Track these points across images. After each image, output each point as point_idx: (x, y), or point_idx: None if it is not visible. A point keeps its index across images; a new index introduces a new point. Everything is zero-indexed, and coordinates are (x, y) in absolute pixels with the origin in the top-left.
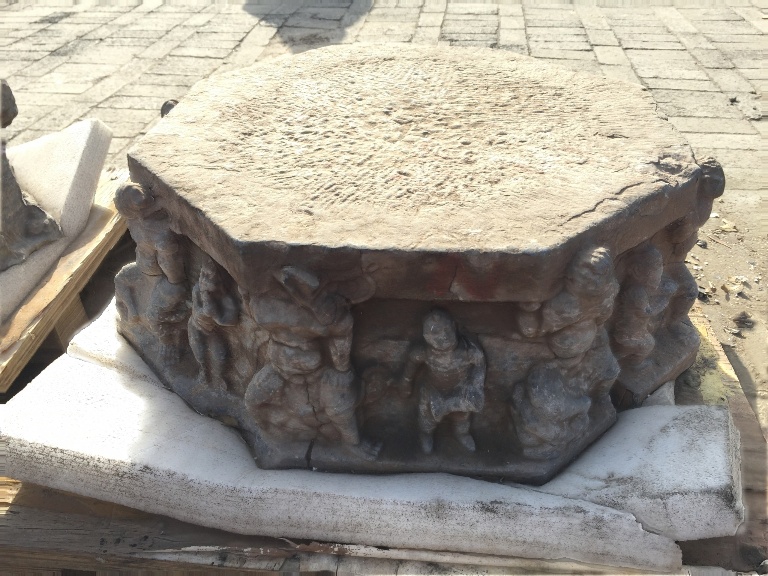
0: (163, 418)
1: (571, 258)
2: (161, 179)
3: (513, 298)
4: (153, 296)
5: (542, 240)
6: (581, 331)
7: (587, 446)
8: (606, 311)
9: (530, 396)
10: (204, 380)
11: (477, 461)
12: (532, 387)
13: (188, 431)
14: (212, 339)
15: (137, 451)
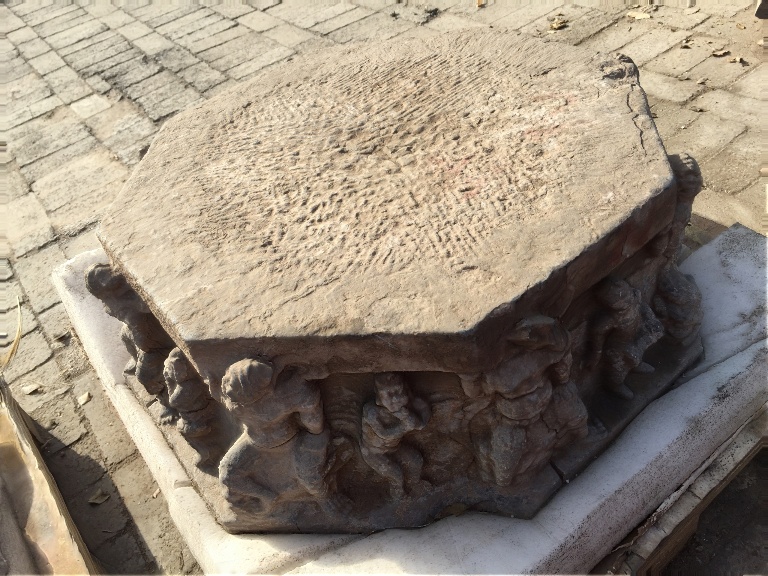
0: (423, 554)
1: None
2: (282, 336)
3: (658, 230)
4: (303, 461)
5: (658, 172)
6: None
7: None
8: None
9: (673, 299)
10: (404, 495)
11: (662, 376)
12: (671, 292)
13: (456, 544)
14: (401, 451)
15: None
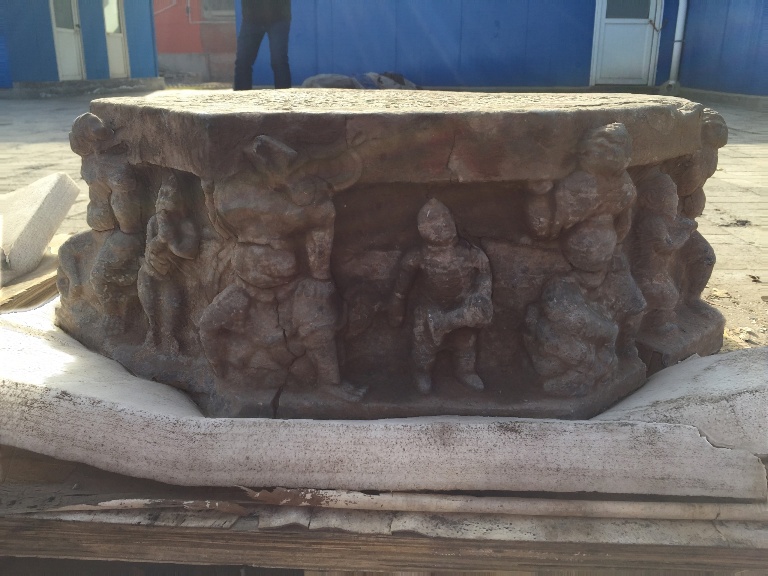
0: (95, 369)
1: (582, 133)
2: (124, 103)
3: (521, 175)
4: (101, 250)
5: None
6: (600, 229)
7: (618, 399)
8: (626, 202)
9: (547, 311)
10: (151, 342)
11: (487, 401)
12: (548, 301)
13: (125, 380)
14: (166, 285)
15: (56, 381)
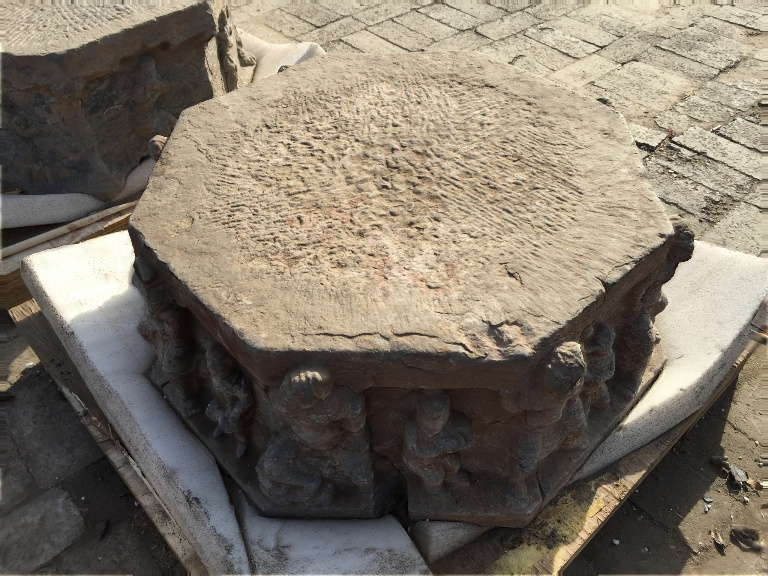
0: (123, 307)
1: (291, 366)
2: (165, 145)
3: (248, 368)
4: None
5: (270, 338)
6: (304, 426)
7: (328, 517)
8: (318, 424)
9: None
10: None
11: (235, 466)
12: None
13: (126, 324)
14: None
15: (80, 320)
